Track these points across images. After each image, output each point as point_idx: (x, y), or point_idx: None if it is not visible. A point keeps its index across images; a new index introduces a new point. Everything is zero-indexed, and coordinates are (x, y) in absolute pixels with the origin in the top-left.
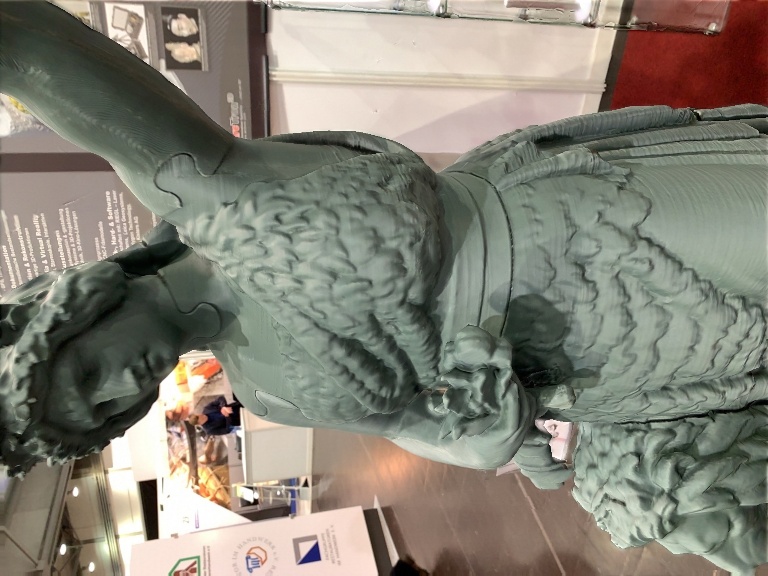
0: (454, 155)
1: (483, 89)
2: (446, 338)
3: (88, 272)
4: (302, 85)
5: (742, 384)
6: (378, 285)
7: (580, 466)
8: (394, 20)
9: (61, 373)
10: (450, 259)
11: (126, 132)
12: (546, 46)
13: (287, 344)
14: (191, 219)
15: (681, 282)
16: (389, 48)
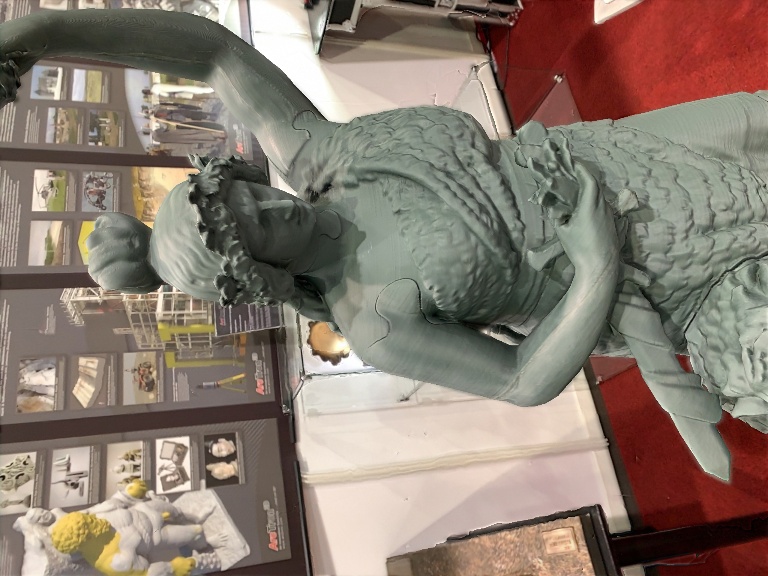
0: None
1: (499, 462)
2: (517, 192)
3: None
4: (332, 486)
5: None
6: (452, 128)
7: (715, 367)
8: (403, 416)
9: (238, 182)
10: (496, 147)
11: (279, 89)
12: (539, 417)
13: (398, 199)
14: (316, 148)
15: (662, 141)
16: (404, 441)
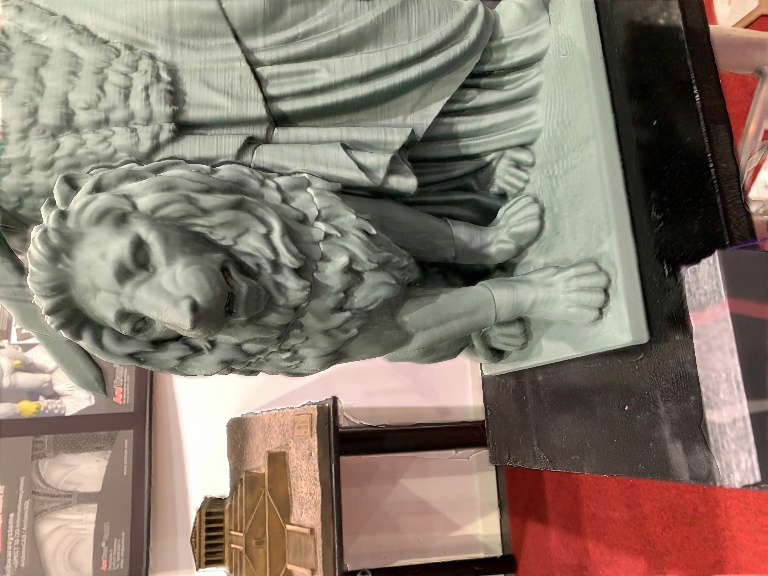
0: (346, 407)
1: None
2: None
3: None
4: None
5: (156, 124)
6: None
7: None
8: None
9: None
10: None
11: None
12: None
13: None
14: None
15: (49, 20)
16: None
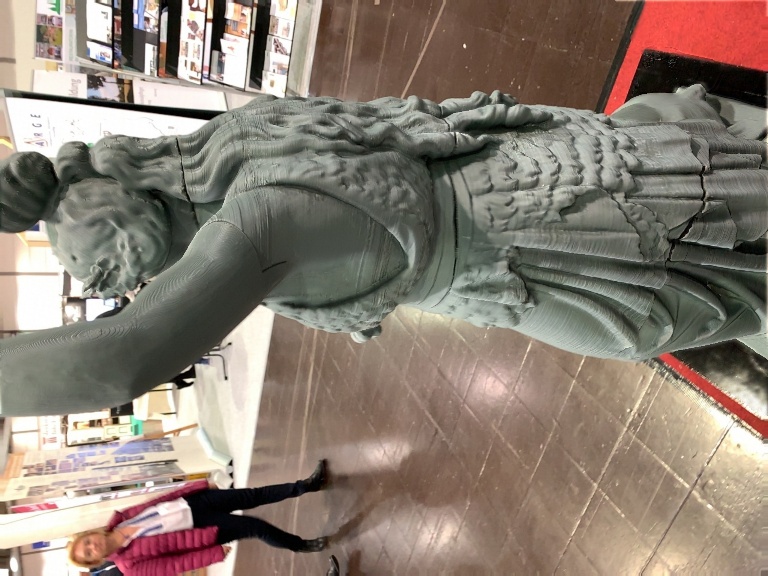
0: None
1: None
2: None
3: (150, 267)
4: None
5: None
6: None
7: None
8: None
9: None
10: None
11: None
12: None
13: None
14: None
15: None
16: None
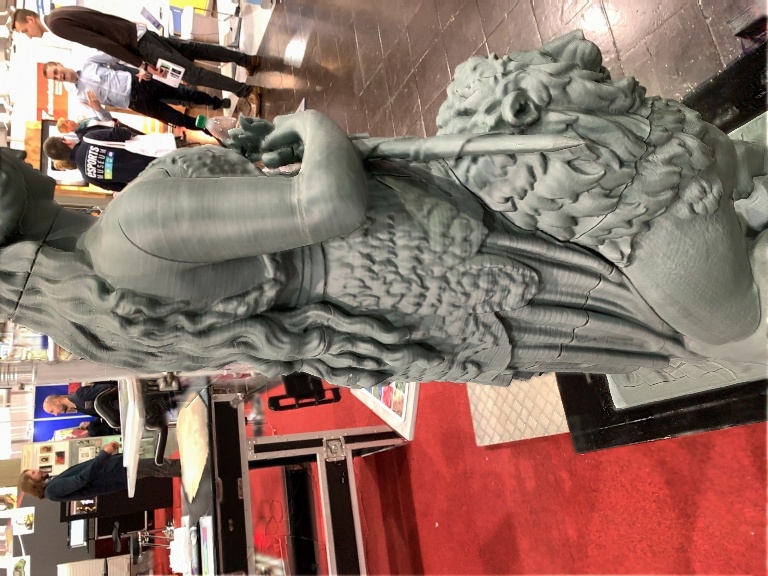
0: None
1: None
2: None
3: None
4: None
5: None
6: None
7: None
8: None
9: None
10: None
11: None
12: None
13: None
14: None
15: None
16: None
